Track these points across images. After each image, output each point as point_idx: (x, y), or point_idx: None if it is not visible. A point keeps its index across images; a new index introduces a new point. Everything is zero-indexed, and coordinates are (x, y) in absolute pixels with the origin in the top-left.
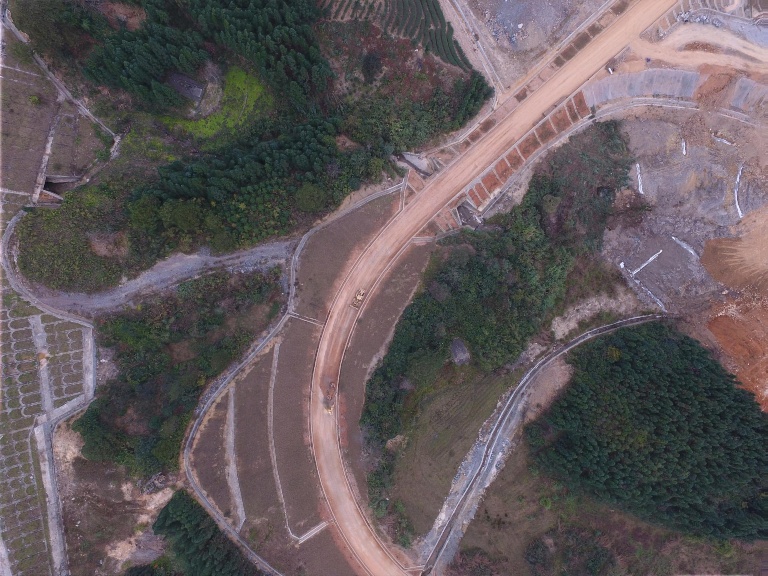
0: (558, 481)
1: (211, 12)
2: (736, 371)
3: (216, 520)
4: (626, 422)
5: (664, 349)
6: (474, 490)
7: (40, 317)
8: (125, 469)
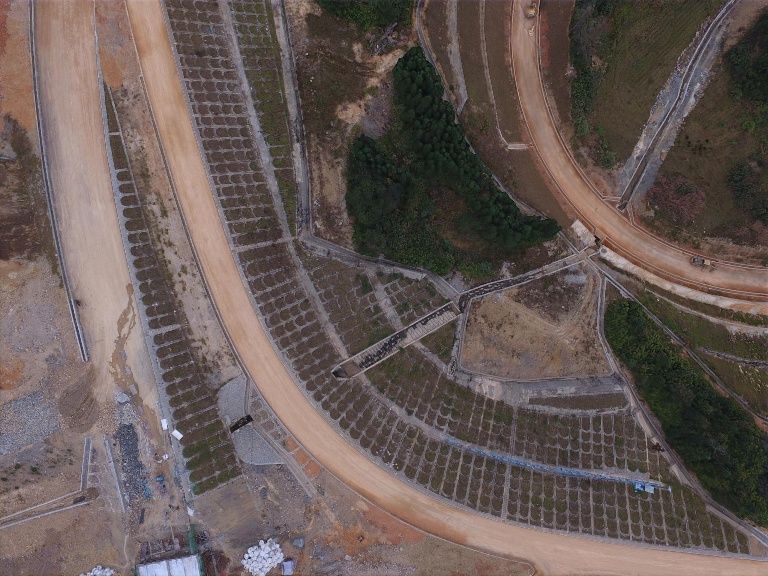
0: (763, 101)
1: None
2: None
3: None
4: None
5: None
6: (671, 123)
7: None
8: (357, 27)
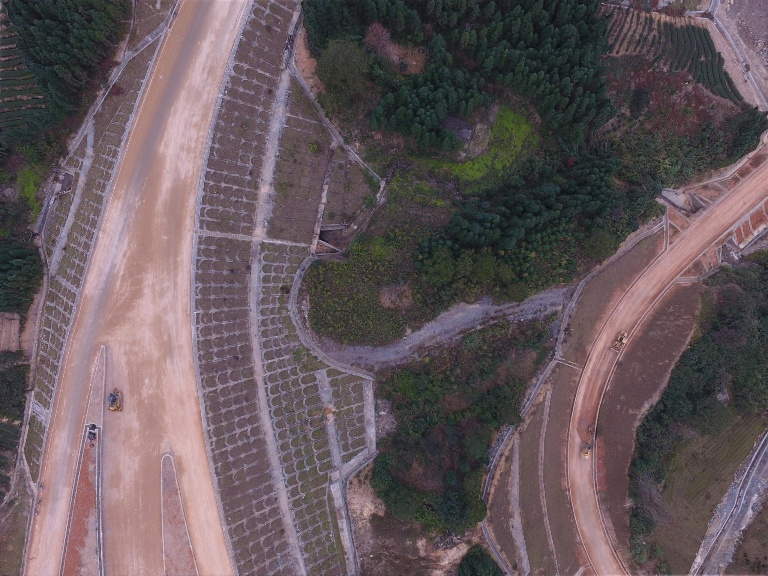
0: None
1: (502, 53)
2: None
3: None
4: None
5: None
6: (728, 532)
7: (326, 371)
8: (421, 525)
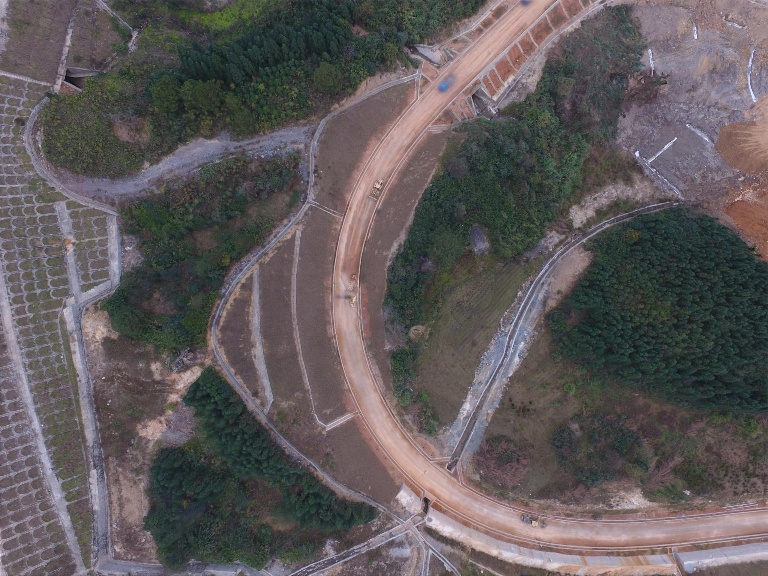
0: (581, 365)
1: None
2: (756, 248)
3: (244, 400)
4: (648, 295)
5: (683, 227)
6: (497, 380)
7: (65, 203)
8: (154, 348)
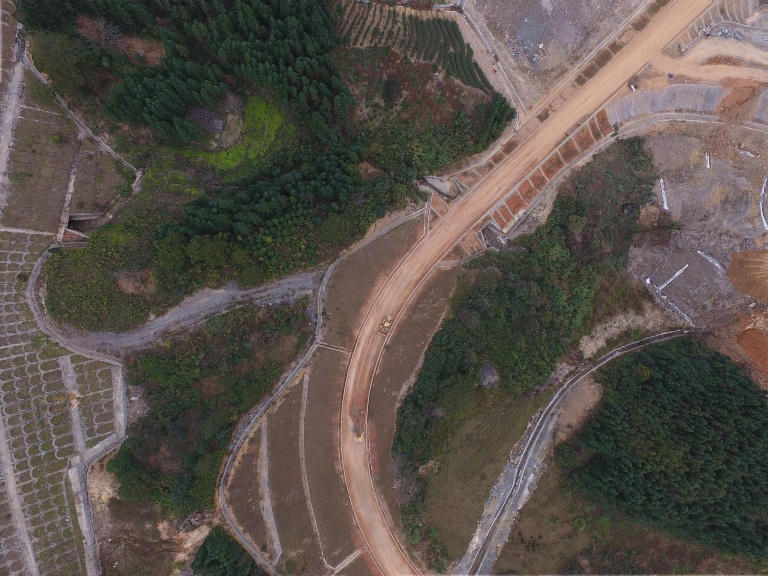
0: (592, 501)
1: (231, 45)
2: (767, 386)
3: (253, 555)
4: (661, 442)
5: (695, 366)
6: (507, 512)
7: (69, 358)
8: (161, 508)
